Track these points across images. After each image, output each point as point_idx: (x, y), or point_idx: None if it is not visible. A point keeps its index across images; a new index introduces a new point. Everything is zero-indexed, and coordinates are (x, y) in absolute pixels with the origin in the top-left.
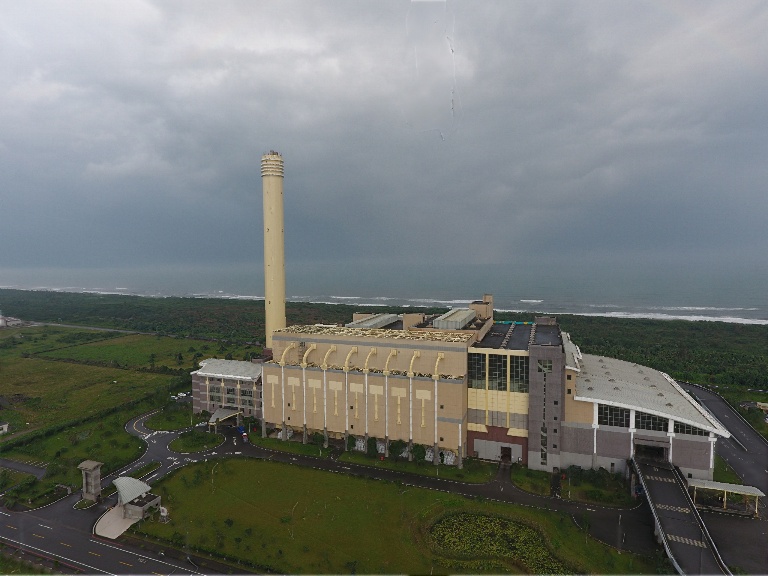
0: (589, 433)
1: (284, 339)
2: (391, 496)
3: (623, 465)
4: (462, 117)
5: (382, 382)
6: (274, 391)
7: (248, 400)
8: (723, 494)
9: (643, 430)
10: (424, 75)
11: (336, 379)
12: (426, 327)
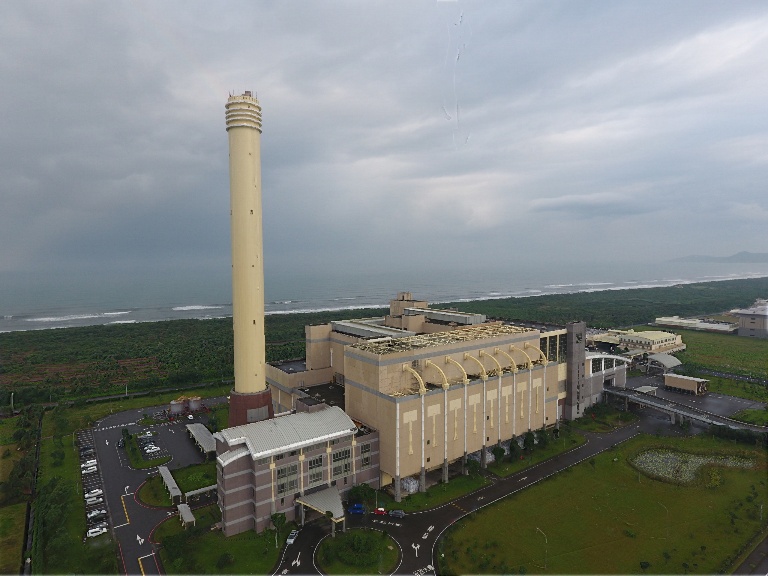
0: (589, 381)
1: (394, 362)
2: (596, 475)
3: (600, 397)
4: (458, 123)
5: (511, 381)
6: (412, 432)
7: (344, 465)
8: (648, 393)
9: (606, 370)
10: (446, 71)
11: (475, 392)
12: (453, 325)
